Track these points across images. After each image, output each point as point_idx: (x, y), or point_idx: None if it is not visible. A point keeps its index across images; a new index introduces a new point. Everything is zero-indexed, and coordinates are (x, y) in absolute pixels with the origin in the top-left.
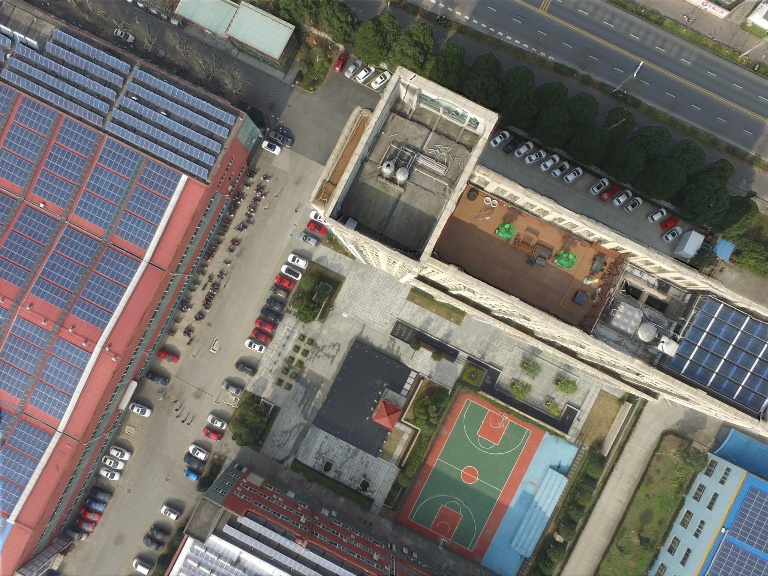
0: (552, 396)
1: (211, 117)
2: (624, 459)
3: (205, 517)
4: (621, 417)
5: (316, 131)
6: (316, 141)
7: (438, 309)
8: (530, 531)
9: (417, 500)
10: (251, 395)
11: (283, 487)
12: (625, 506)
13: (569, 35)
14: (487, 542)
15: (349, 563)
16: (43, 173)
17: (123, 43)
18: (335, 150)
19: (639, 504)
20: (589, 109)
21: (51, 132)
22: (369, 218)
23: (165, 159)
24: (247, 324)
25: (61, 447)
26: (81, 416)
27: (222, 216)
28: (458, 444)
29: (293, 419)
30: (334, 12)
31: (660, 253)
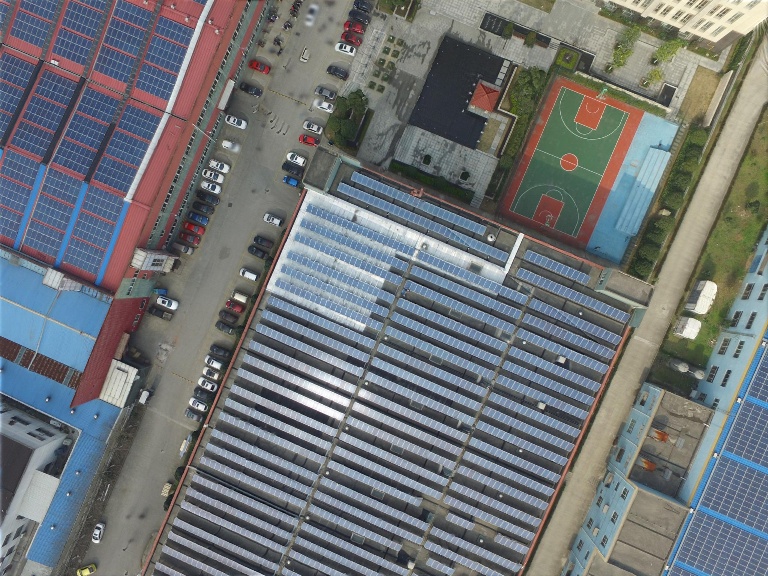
0: (648, 77)
1: None
2: (726, 134)
3: (322, 166)
4: (722, 87)
5: None
6: None
7: None
8: (635, 209)
9: (517, 191)
10: None
11: None
12: (730, 181)
13: None
14: (591, 228)
15: (465, 214)
16: None
17: None
18: None
19: (744, 178)
20: None
21: None
22: None
23: None
24: (335, 30)
25: (170, 128)
26: (188, 95)
27: None
28: (555, 133)
29: (388, 121)
30: None
31: None
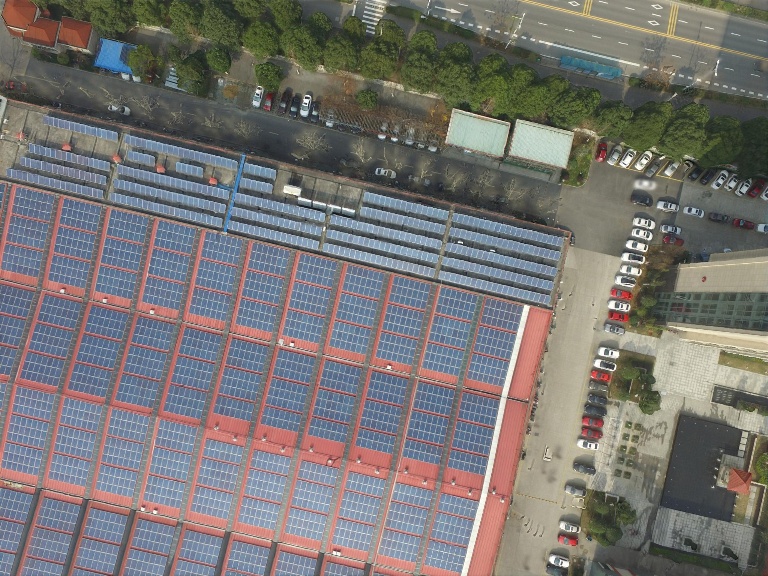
0: None
1: (537, 243)
2: None
3: None
4: None
5: (593, 223)
6: (595, 233)
7: (750, 366)
8: None
9: None
10: (594, 493)
11: (648, 573)
12: None
13: None
14: None
15: None
16: (383, 335)
17: (387, 181)
18: None
19: None
20: None
21: (383, 294)
22: None
23: (503, 294)
24: (573, 425)
25: None
26: (479, 564)
27: None
28: None
29: (639, 505)
30: (619, 113)
31: None
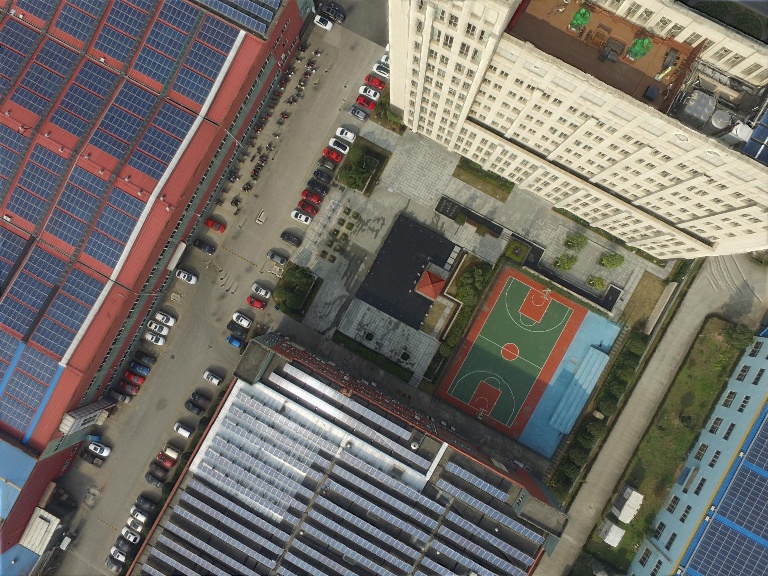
0: (595, 276)
1: None
2: (667, 341)
3: (253, 360)
4: (665, 296)
5: (368, 8)
6: (367, 18)
7: (483, 186)
8: (570, 408)
9: (457, 375)
10: (295, 266)
11: (324, 357)
12: (666, 388)
13: None
14: (525, 419)
15: (392, 416)
16: (105, 28)
17: None
18: None
19: (681, 386)
20: None
21: None
22: None
23: (224, 15)
24: (293, 196)
25: (113, 295)
26: (133, 265)
27: (273, 88)
28: (499, 321)
29: (336, 291)
30: None
31: (739, 32)
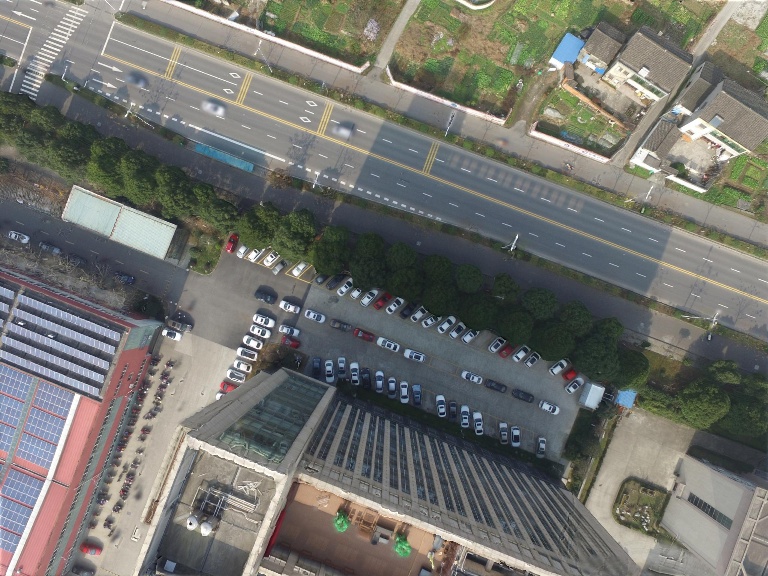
0: None
1: (97, 334)
2: None
3: None
4: None
5: (214, 313)
6: (215, 323)
7: None
8: None
9: None
10: None
11: None
12: None
13: (454, 194)
14: None
15: None
16: None
17: (18, 245)
18: (161, 469)
19: None
20: (472, 283)
21: None
22: (187, 557)
23: (57, 380)
24: None
25: None
26: None
27: (130, 407)
28: None
29: None
30: (210, 214)
31: (486, 547)
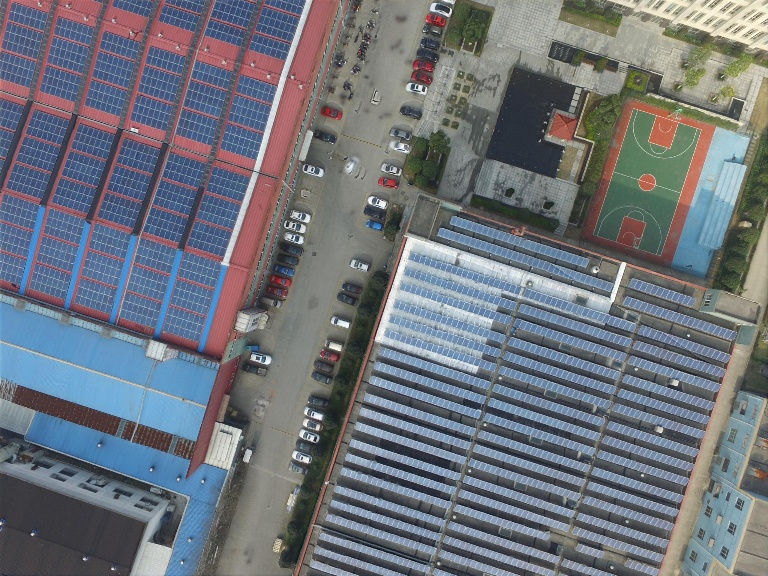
0: (716, 92)
1: None
2: None
3: (424, 215)
4: None
5: None
6: None
7: (591, 24)
8: (716, 223)
9: (599, 215)
10: None
11: None
12: None
13: None
14: (674, 245)
15: (566, 248)
16: None
17: None
18: None
19: None
20: None
21: None
22: None
23: None
24: (404, 70)
25: (260, 187)
26: (275, 152)
27: None
28: (631, 154)
29: (465, 157)
30: None
31: None
